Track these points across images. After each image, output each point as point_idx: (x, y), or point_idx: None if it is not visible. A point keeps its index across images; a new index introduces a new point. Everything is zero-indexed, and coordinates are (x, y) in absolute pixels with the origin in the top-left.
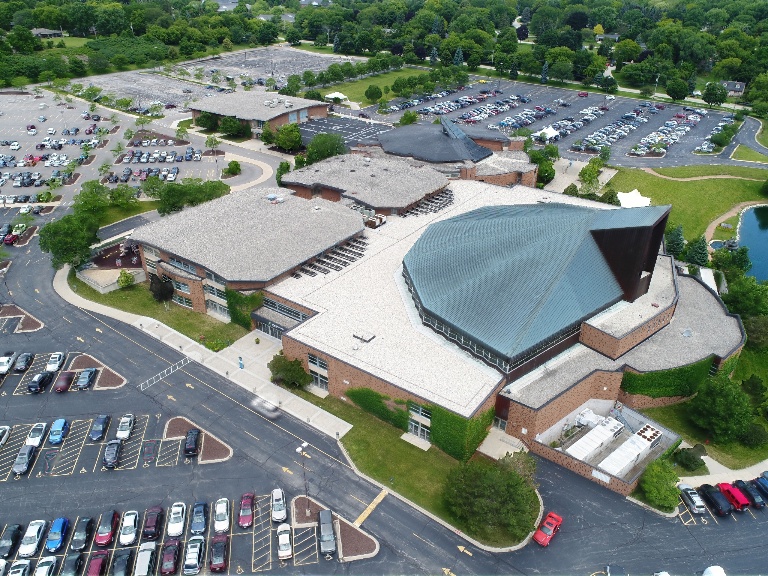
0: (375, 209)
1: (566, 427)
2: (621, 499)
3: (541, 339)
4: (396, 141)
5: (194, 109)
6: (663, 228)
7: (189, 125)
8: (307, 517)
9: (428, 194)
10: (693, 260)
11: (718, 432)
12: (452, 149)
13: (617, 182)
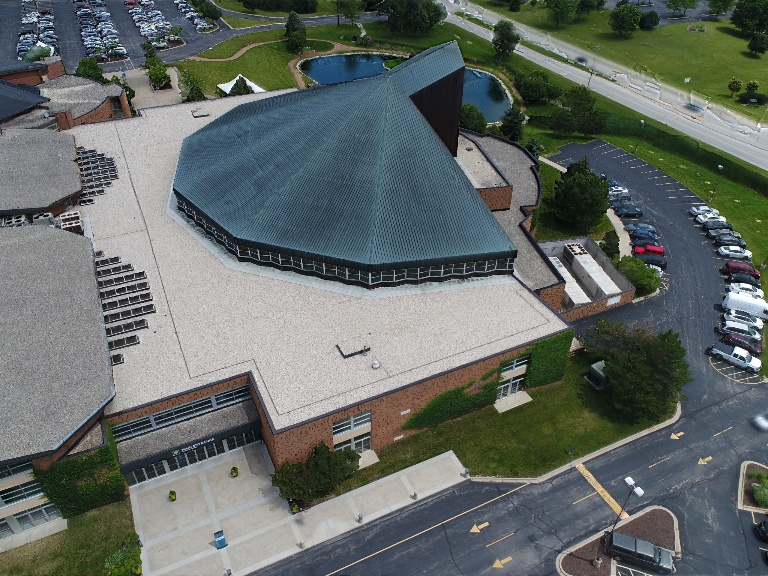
0: None
1: None
2: (634, 306)
3: None
4: None
5: None
6: None
7: None
8: (602, 568)
9: (75, 160)
10: None
11: None
12: None
13: None
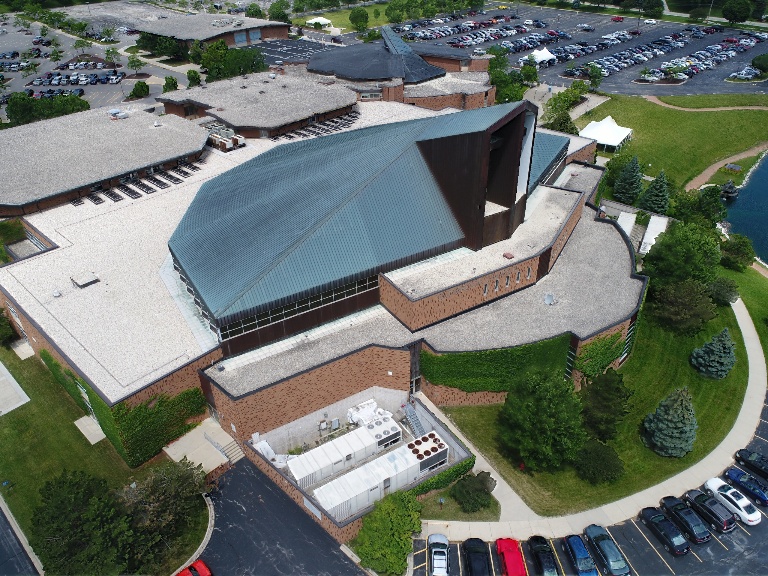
0: (238, 129)
1: (327, 425)
2: (331, 548)
3: (286, 294)
4: (326, 58)
5: (140, 31)
6: (517, 138)
7: (138, 50)
8: None
9: (318, 114)
10: (646, 205)
11: (523, 455)
12: (385, 66)
13: (601, 111)
